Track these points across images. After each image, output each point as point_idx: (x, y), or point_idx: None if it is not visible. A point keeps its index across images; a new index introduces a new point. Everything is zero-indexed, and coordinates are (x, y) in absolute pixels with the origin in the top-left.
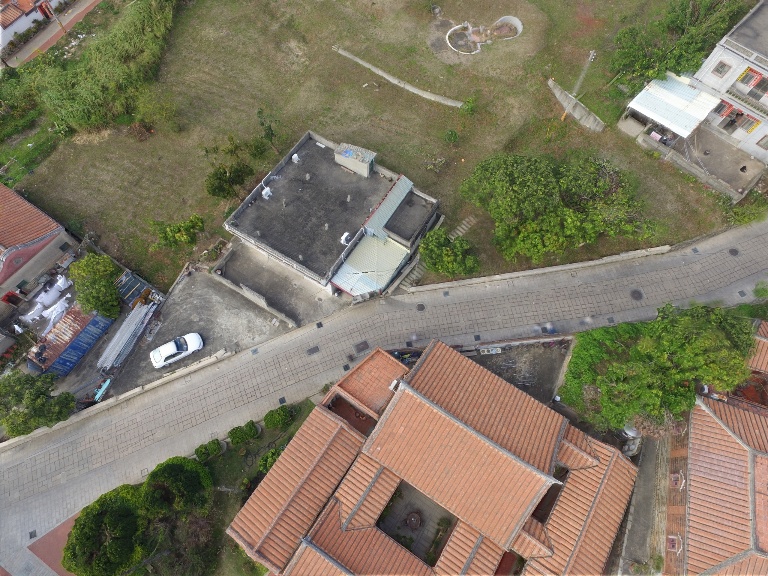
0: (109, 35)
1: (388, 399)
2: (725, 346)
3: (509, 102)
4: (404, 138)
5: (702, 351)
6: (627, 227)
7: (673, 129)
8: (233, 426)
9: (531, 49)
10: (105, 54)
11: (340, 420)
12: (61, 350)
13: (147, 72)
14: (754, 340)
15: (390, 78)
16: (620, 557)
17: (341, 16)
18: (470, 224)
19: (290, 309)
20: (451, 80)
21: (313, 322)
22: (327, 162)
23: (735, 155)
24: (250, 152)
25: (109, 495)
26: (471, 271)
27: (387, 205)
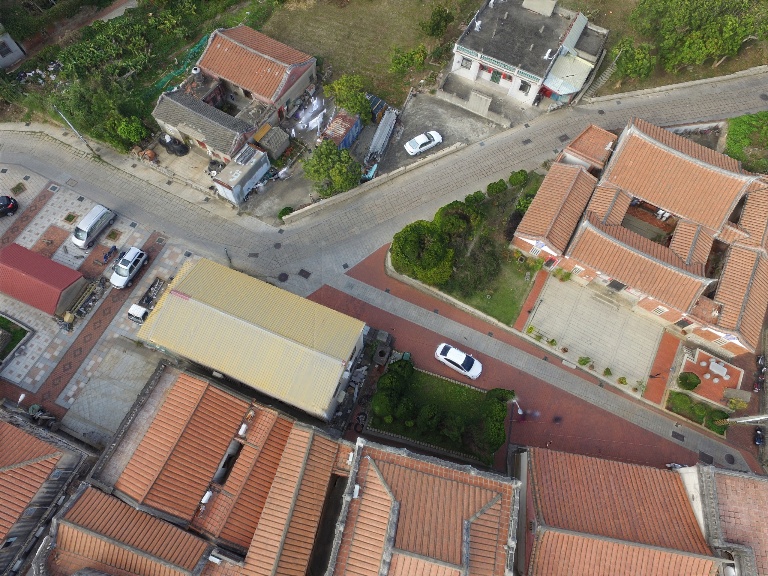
0: None
1: (607, 155)
2: None
3: None
4: None
5: None
6: None
7: None
8: (481, 190)
9: None
10: None
11: None
12: (340, 140)
13: None
14: None
15: None
16: None
17: None
18: None
19: None
20: None
21: (521, 124)
22: (516, 7)
23: None
24: None
25: (414, 224)
26: (647, 75)
27: (574, 32)
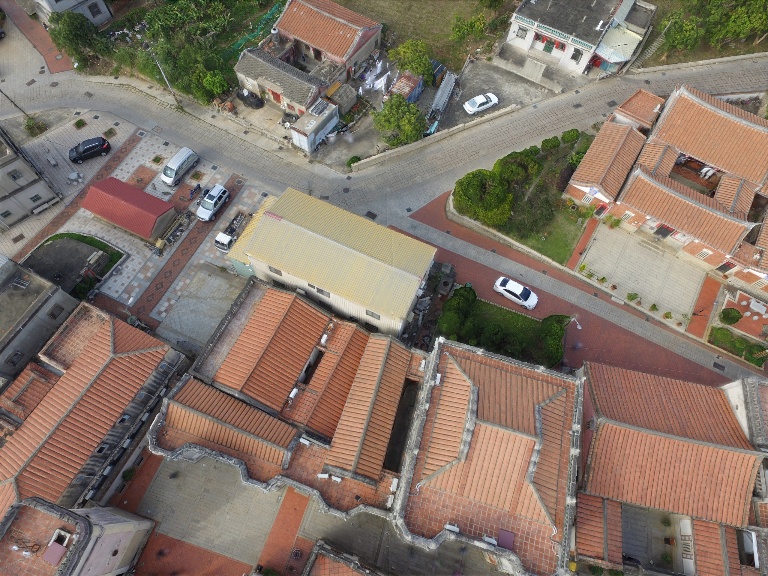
0: None
1: (655, 116)
2: None
3: None
4: None
5: None
6: None
7: None
8: None
9: None
10: None
11: (630, 123)
12: (405, 97)
13: None
14: None
15: None
16: None
17: None
18: None
19: None
20: None
21: (572, 90)
22: None
23: None
24: None
25: (475, 172)
26: (692, 47)
27: (624, 6)
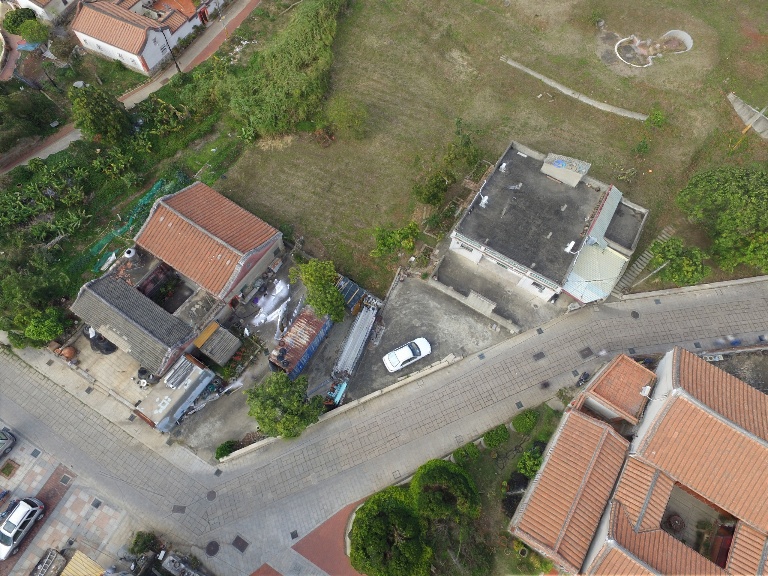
0: (281, 42)
1: (643, 405)
2: None
3: (691, 115)
4: (589, 148)
5: None
6: None
7: None
8: (476, 430)
9: (708, 63)
10: (282, 61)
11: (606, 425)
12: (301, 354)
13: (323, 79)
14: None
15: (564, 89)
16: None
17: (504, 27)
18: (670, 234)
19: (509, 315)
20: (628, 92)
21: (533, 328)
22: (533, 171)
23: None
24: (467, 161)
25: (383, 497)
26: None
27: (605, 215)
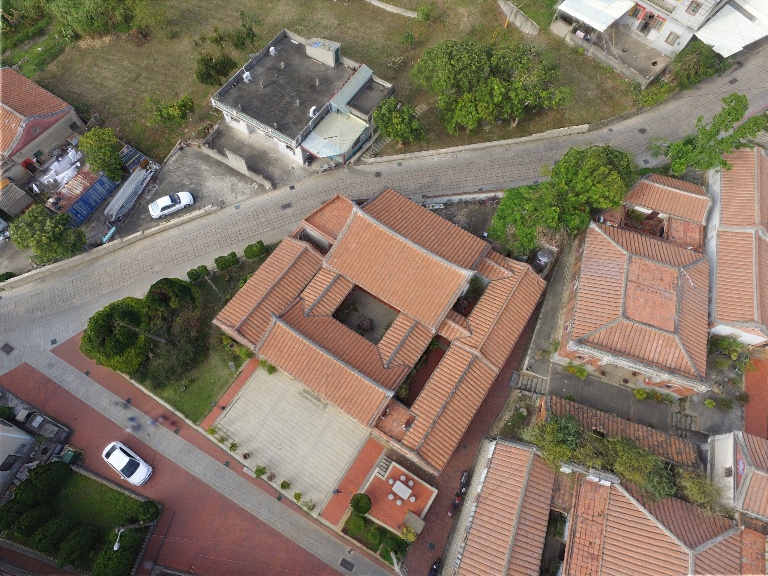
0: None
1: None
2: (606, 167)
3: (460, 11)
4: (369, 42)
5: (590, 173)
6: (543, 93)
7: (592, 25)
8: None
9: None
10: None
11: (305, 242)
12: (74, 201)
13: None
14: (643, 183)
15: None
16: (529, 348)
17: None
18: (422, 110)
19: (267, 175)
20: None
21: (287, 185)
22: (300, 55)
23: (649, 53)
24: (233, 42)
25: (117, 302)
26: (418, 138)
27: (349, 87)
